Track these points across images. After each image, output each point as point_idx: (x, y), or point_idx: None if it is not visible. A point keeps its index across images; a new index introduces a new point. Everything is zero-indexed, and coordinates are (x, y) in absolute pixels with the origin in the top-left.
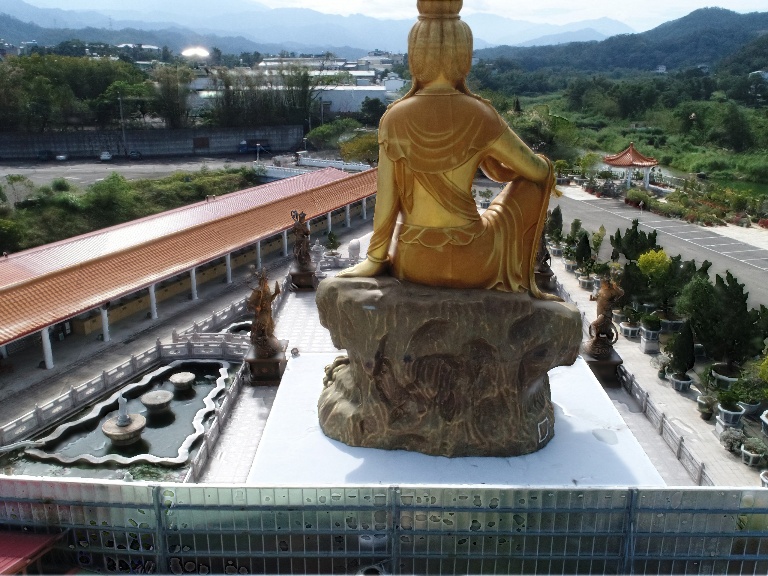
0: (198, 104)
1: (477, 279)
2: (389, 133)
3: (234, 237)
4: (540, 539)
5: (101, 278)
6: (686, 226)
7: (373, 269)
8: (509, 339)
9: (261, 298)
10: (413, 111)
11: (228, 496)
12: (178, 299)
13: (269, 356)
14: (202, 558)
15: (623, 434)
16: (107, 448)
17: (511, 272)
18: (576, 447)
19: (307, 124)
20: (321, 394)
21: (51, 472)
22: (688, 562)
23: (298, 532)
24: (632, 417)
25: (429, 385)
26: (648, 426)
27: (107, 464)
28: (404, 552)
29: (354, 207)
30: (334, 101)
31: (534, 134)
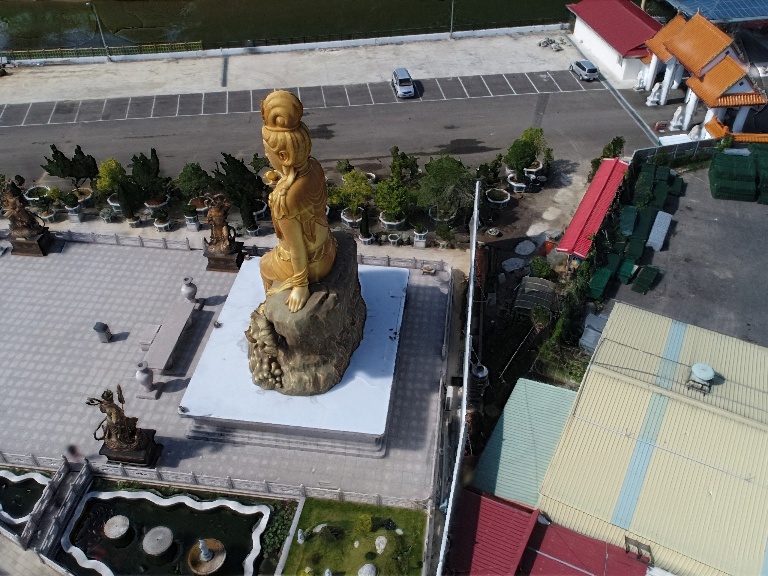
0: None
1: None
2: (299, 209)
3: None
4: None
5: None
6: None
7: None
8: None
9: (121, 410)
10: None
11: None
12: None
13: (148, 439)
14: None
15: None
16: None
17: None
18: (362, 288)
19: None
20: (294, 385)
21: None
22: None
23: None
24: None
25: None
26: None
27: (255, 566)
28: None
29: None
30: None
31: None
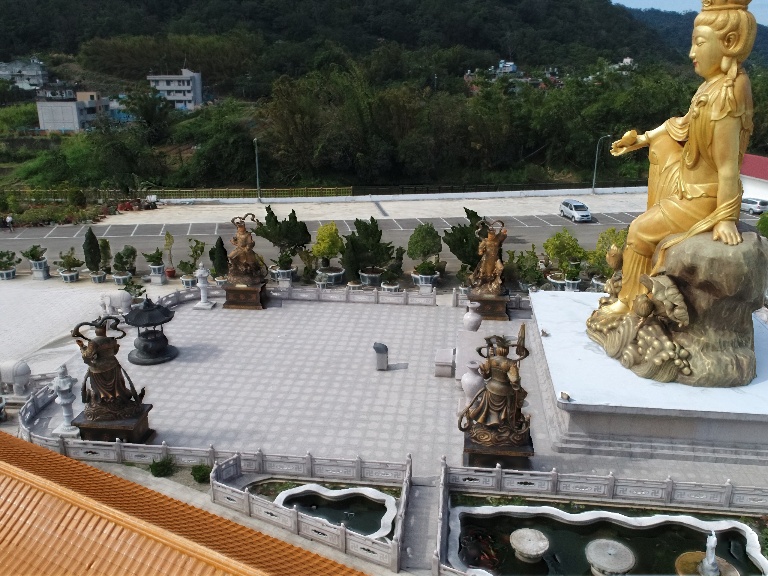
0: None
1: None
2: None
3: None
4: None
5: (292, 575)
6: (85, 227)
7: None
8: None
9: None
10: None
11: None
12: None
13: None
14: None
15: None
16: None
17: None
18: None
19: None
20: (712, 367)
21: None
22: None
23: None
24: None
25: None
26: None
27: None
28: None
29: None
30: None
31: None
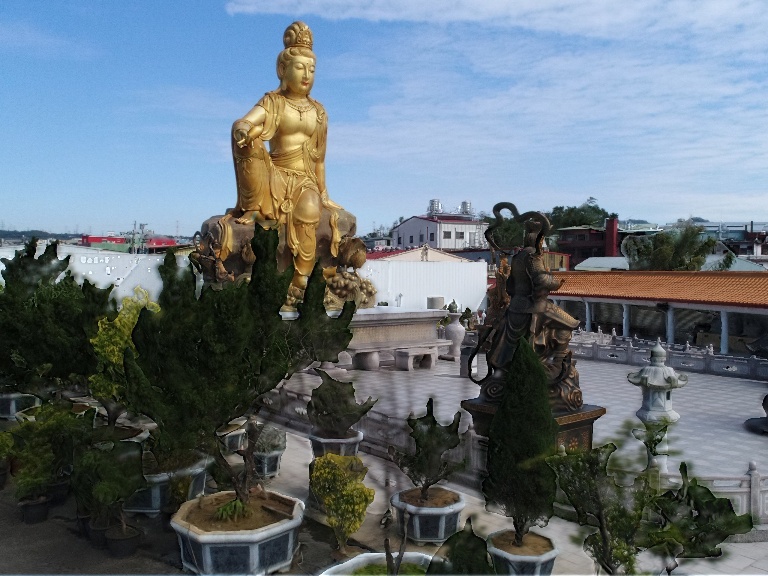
0: None
1: None
2: None
3: None
4: None
5: (687, 286)
6: None
7: None
8: None
9: None
10: None
11: None
12: None
13: None
14: None
15: None
16: None
17: None
18: None
19: None
20: None
21: None
22: (129, 290)
23: None
24: None
25: None
26: None
27: None
28: None
29: None
30: None
31: None
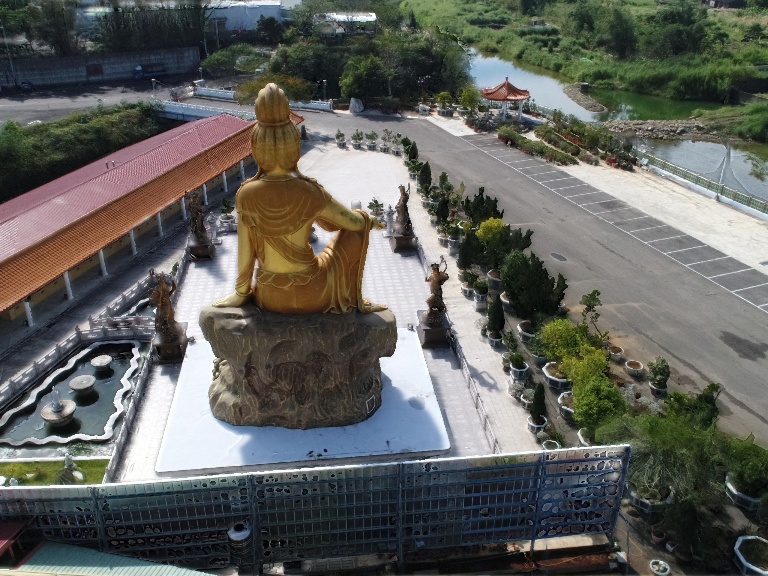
0: (87, 28)
1: (316, 307)
2: (243, 206)
3: (135, 214)
4: (347, 496)
5: (20, 274)
6: (544, 166)
7: (240, 301)
8: (340, 349)
9: (161, 296)
10: (259, 193)
11: (142, 488)
12: (90, 276)
13: (172, 340)
14: (129, 526)
15: (430, 400)
16: (46, 427)
17: (341, 298)
18: (395, 414)
19: (203, 45)
20: (211, 385)
21: (5, 454)
22: (440, 500)
23: (191, 505)
24: (452, 374)
25: (286, 382)
26: (462, 381)
27: (49, 444)
28: (261, 510)
29: (249, 156)
30: (229, 17)
31: (425, 56)
